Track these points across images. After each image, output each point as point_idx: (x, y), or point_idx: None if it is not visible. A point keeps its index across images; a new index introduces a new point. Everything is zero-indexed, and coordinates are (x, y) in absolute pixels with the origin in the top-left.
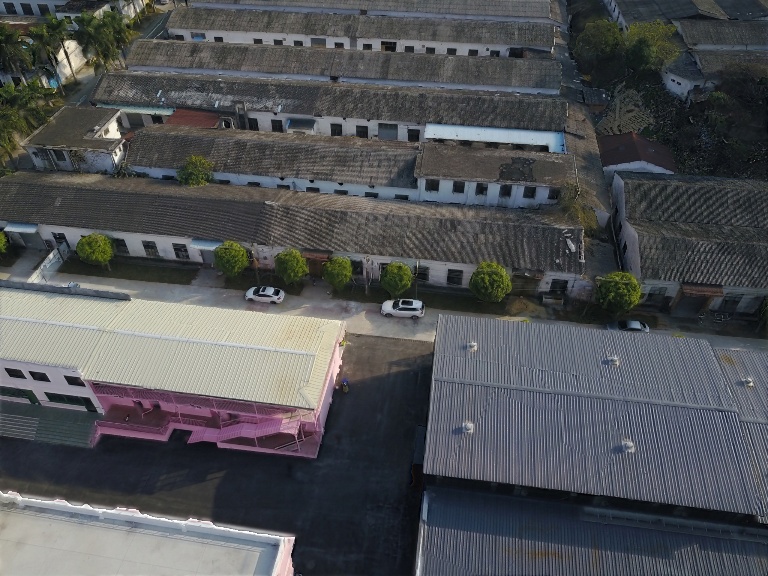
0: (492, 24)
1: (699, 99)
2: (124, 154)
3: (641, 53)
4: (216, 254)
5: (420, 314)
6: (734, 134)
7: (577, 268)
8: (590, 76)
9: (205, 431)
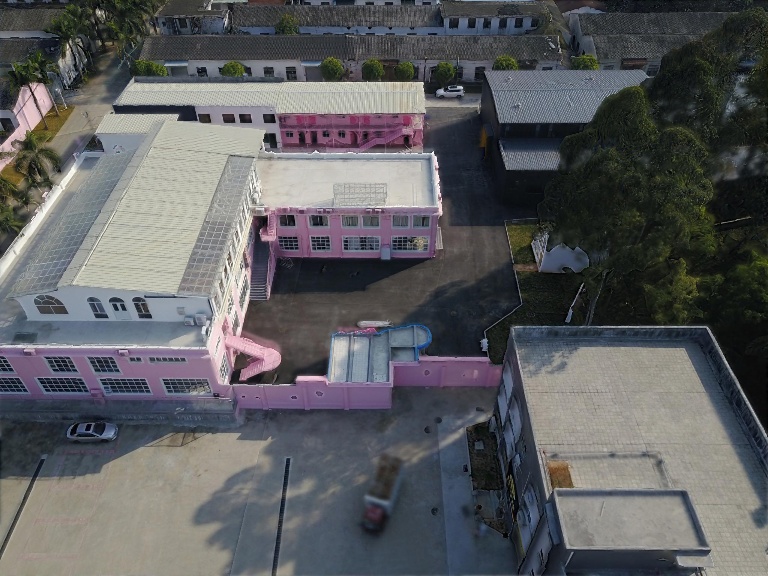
0: None
1: None
2: (230, 20)
3: None
4: (323, 65)
5: (462, 93)
6: None
7: (558, 57)
8: None
9: (350, 150)
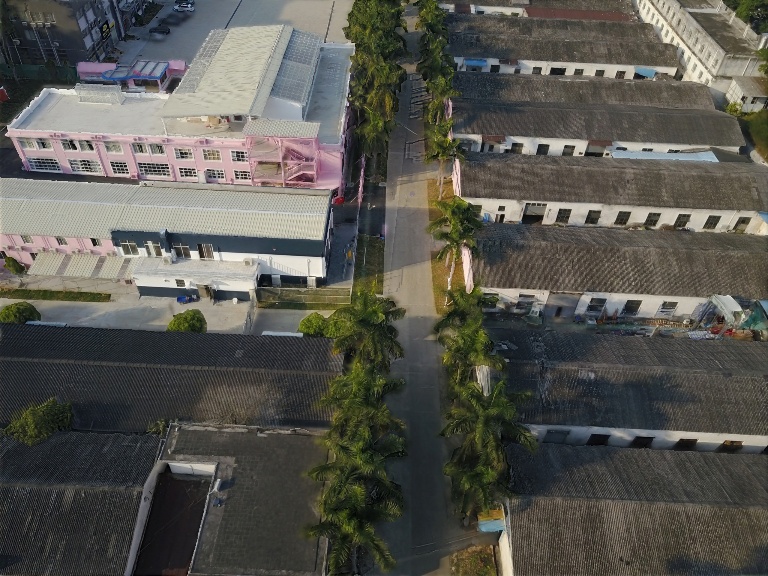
0: None
1: None
2: None
3: None
4: (31, 306)
5: None
6: None
7: None
8: None
9: None
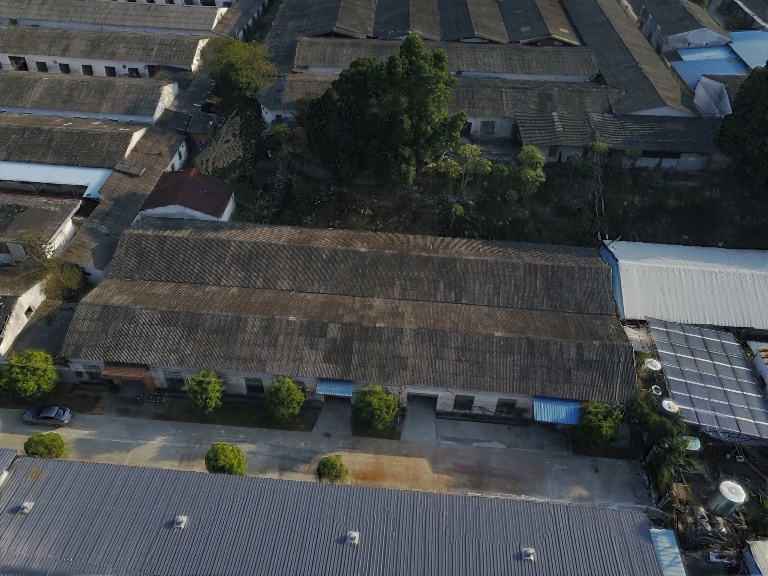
0: (133, 38)
1: (271, 132)
2: None
3: (228, 78)
4: None
5: None
6: (308, 171)
7: None
8: (221, 98)
9: None
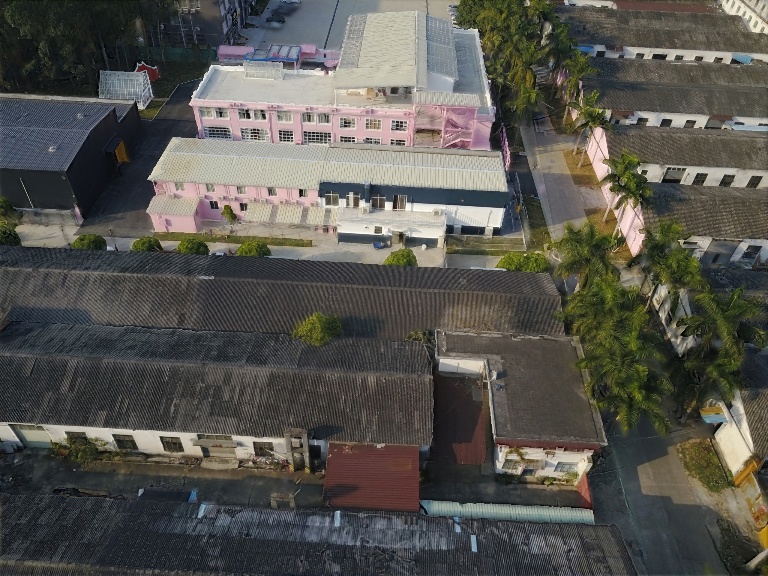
0: None
1: None
2: None
3: None
4: None
5: None
6: None
7: None
8: None
9: None
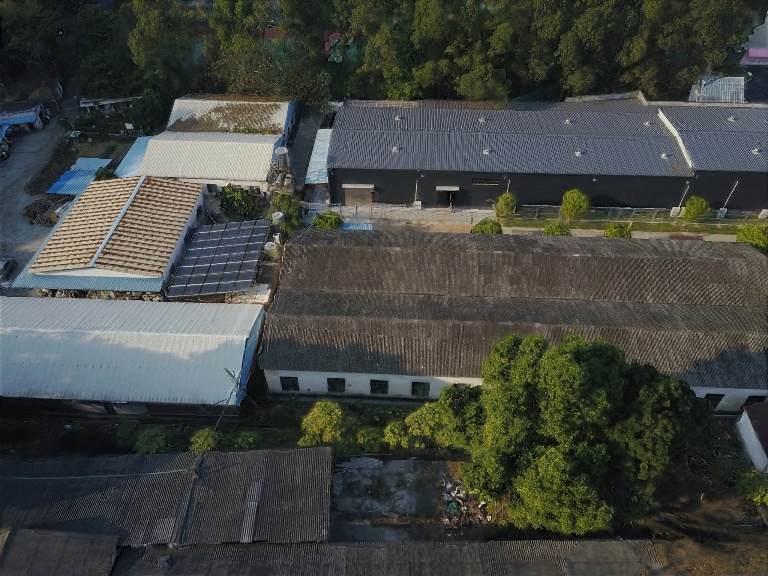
0: None
1: None
2: None
3: None
4: None
5: None
6: None
7: None
8: None
9: None
